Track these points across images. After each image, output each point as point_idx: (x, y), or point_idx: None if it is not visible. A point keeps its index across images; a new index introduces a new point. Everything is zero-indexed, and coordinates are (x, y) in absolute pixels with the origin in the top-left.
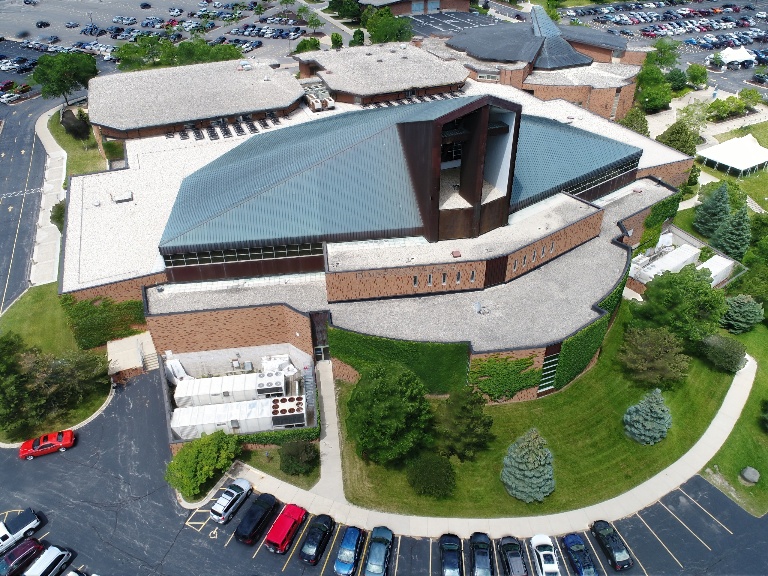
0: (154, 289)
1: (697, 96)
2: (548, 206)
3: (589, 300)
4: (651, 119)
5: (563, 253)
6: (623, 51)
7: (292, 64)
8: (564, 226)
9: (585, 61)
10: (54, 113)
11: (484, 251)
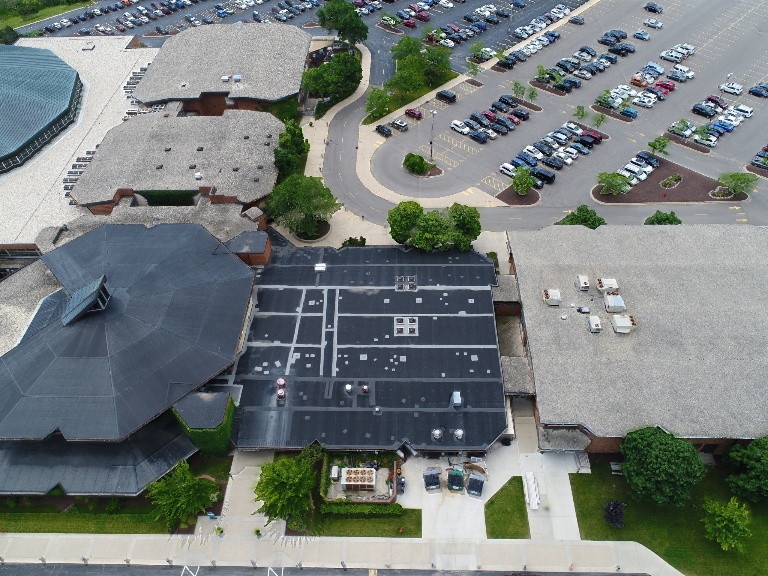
0: None
1: None
2: None
3: None
4: None
5: None
6: None
7: (368, 152)
8: None
9: None
10: (335, 39)
11: None
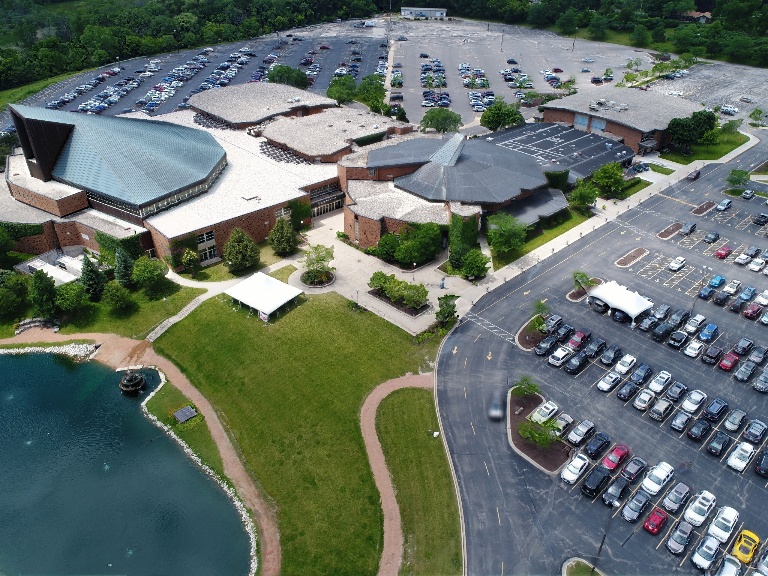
0: None
1: (448, 281)
2: (65, 189)
3: None
4: (372, 262)
5: (41, 209)
6: None
7: None
8: (36, 192)
9: (427, 195)
10: None
11: (17, 179)
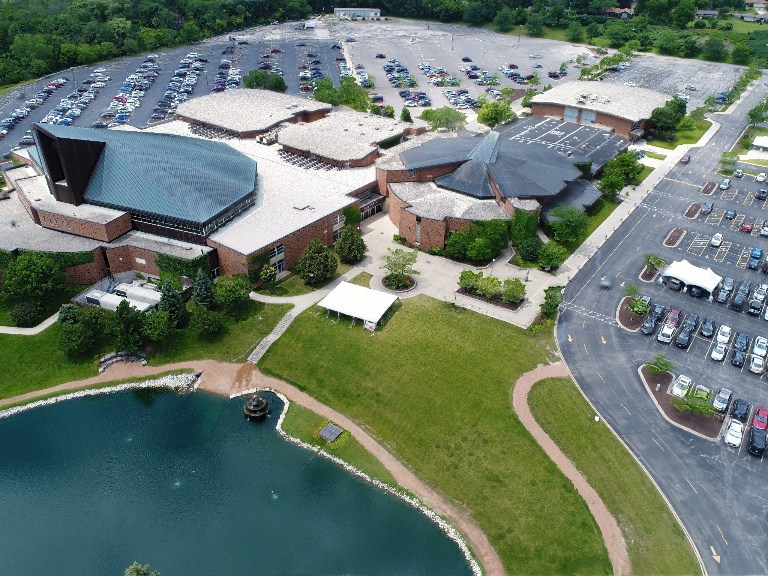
0: (28, 166)
1: None
2: (105, 212)
3: (28, 248)
4: (441, 262)
5: (81, 236)
6: (504, 198)
7: None
8: None
9: (476, 193)
10: None
11: None
